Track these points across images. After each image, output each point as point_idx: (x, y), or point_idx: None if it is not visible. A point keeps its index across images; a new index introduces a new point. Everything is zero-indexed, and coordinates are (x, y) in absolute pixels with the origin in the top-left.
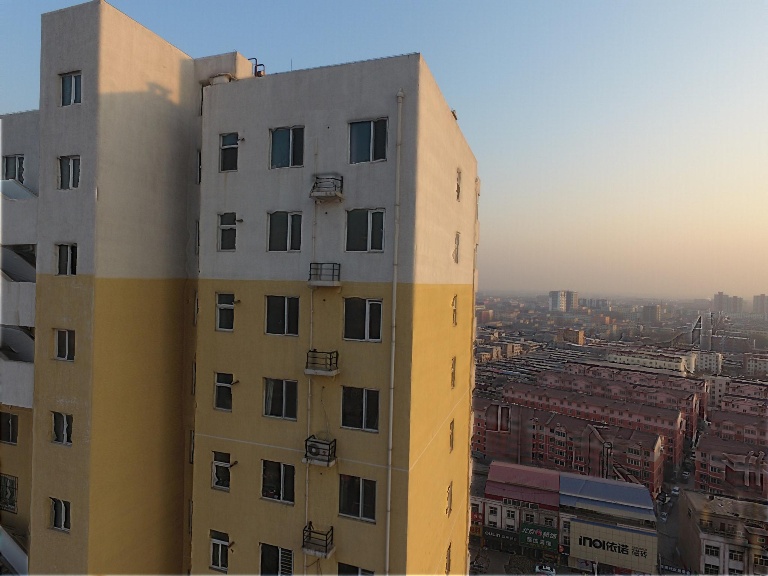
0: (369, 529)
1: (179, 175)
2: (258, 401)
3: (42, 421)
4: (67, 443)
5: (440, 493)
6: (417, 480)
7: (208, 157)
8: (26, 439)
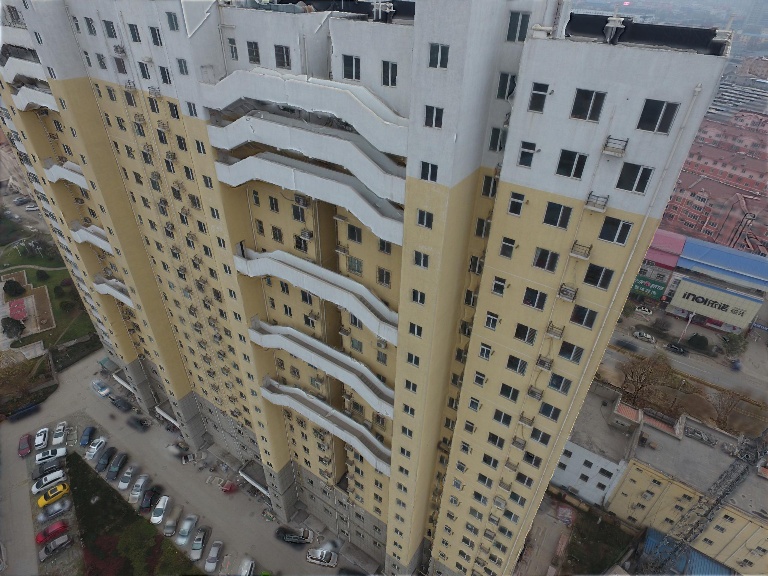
0: (587, 332)
1: (487, 96)
2: (531, 258)
3: (409, 254)
4: (423, 267)
5: None
6: None
7: (520, 98)
8: (368, 243)
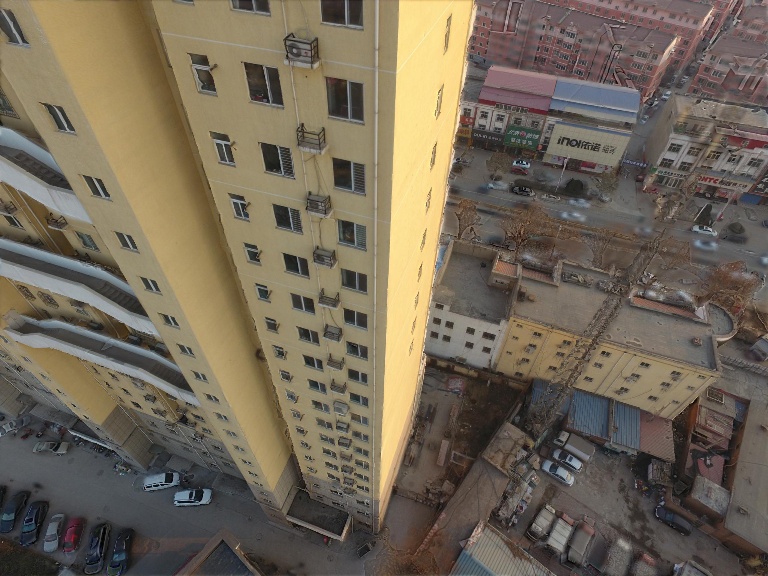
0: (358, 129)
1: None
2: None
3: None
4: (24, 44)
5: (430, 96)
6: (405, 83)
7: None
8: None
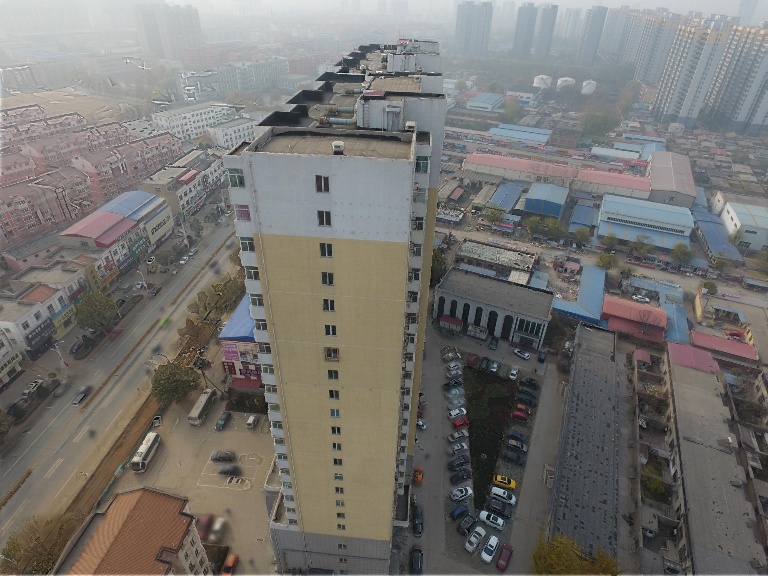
0: None
1: None
2: None
3: None
4: None
5: None
6: None
7: None
8: None
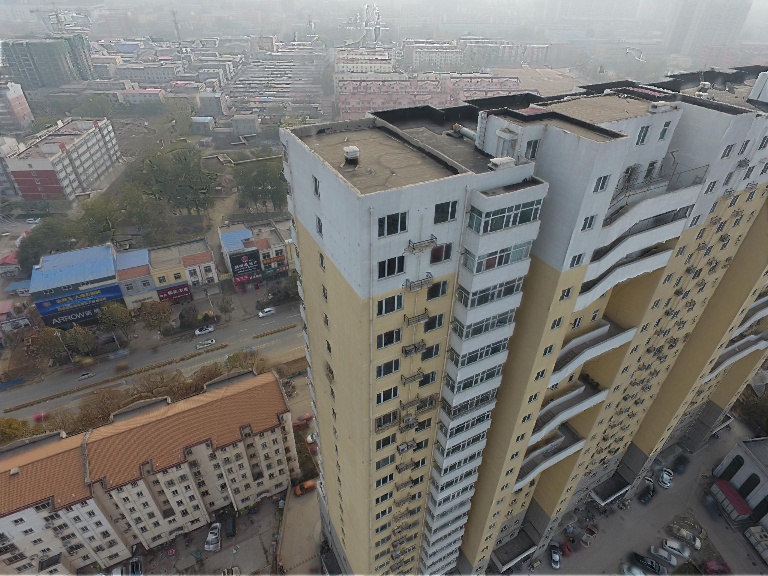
0: None
1: None
2: None
3: None
4: None
5: None
6: None
7: None
8: None
